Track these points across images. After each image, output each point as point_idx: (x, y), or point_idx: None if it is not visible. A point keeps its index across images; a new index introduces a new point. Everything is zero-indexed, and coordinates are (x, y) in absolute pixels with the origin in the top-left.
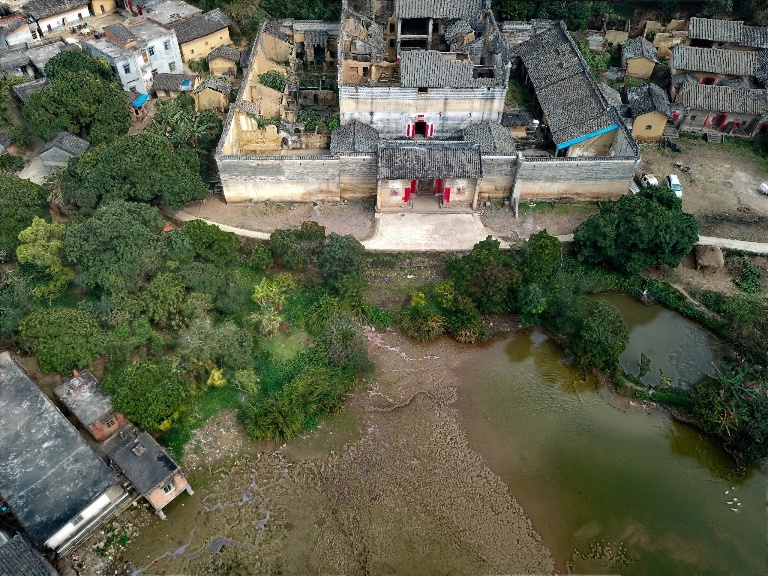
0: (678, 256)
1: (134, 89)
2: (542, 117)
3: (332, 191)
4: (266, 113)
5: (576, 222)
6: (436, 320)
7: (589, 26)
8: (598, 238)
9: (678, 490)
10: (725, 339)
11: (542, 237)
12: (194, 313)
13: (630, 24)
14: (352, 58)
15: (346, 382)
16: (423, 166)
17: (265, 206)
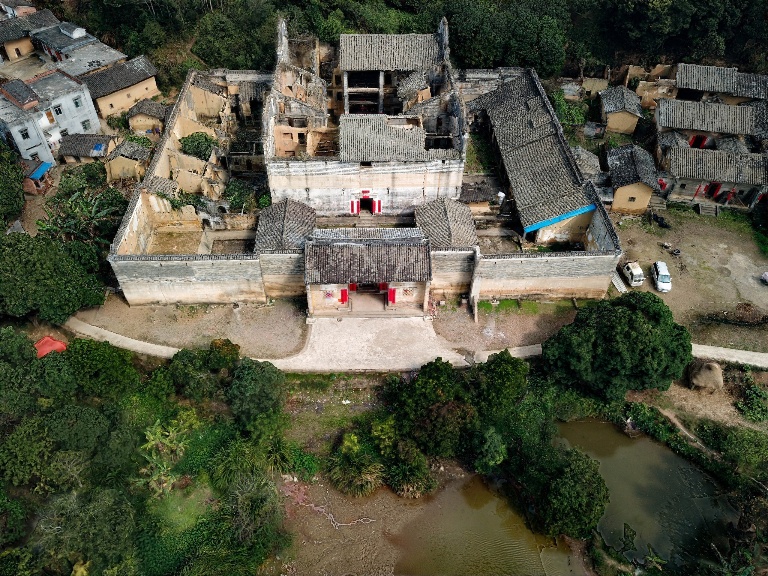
0: (668, 378)
1: (34, 157)
2: (509, 187)
3: (255, 291)
4: (186, 186)
5: (546, 326)
6: (371, 471)
7: (564, 71)
8: (571, 359)
9: None
10: (727, 487)
11: (502, 360)
12: (59, 479)
13: (610, 68)
14: (287, 121)
15: (252, 568)
16: (360, 267)
17: (176, 309)
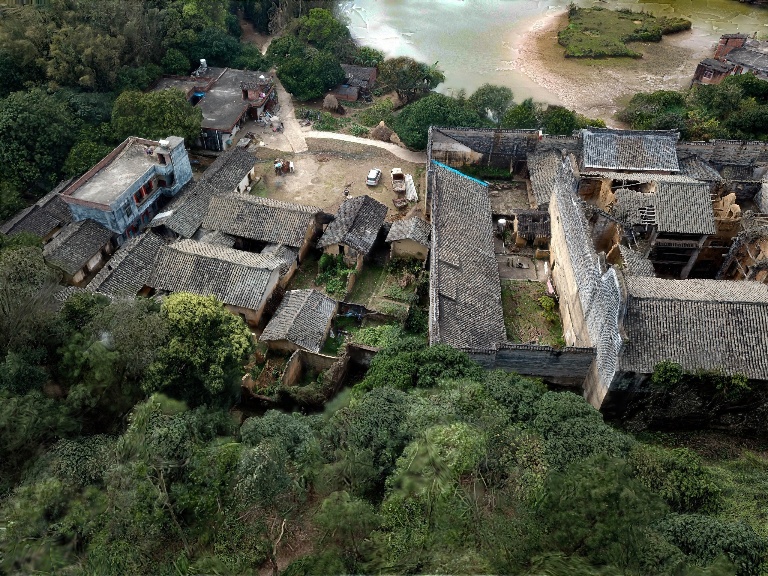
0: None
1: None
2: None
3: None
4: None
5: None
6: None
7: None
8: None
9: (456, 82)
10: None
11: None
12: None
13: None
14: None
15: None
16: None
17: None
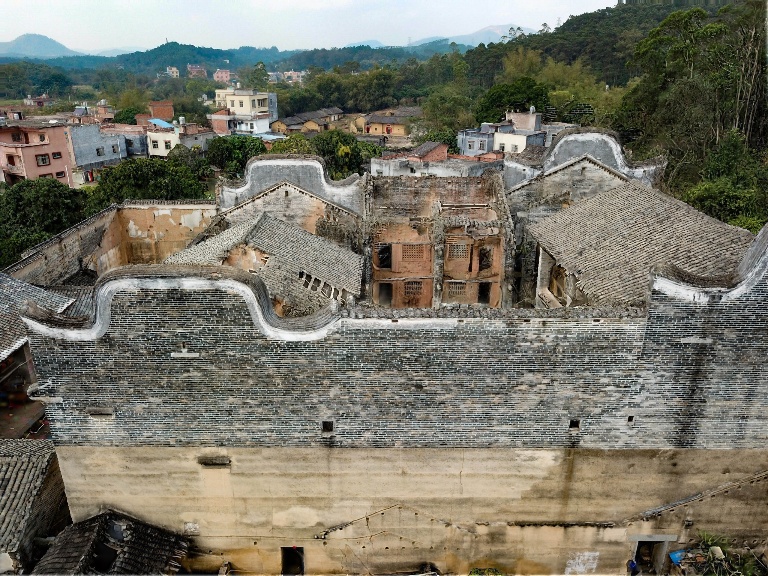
0: None
1: None
2: None
3: None
4: None
5: None
6: None
7: None
8: None
9: None
10: None
11: None
12: None
13: None
14: None
15: None
16: None
17: None
